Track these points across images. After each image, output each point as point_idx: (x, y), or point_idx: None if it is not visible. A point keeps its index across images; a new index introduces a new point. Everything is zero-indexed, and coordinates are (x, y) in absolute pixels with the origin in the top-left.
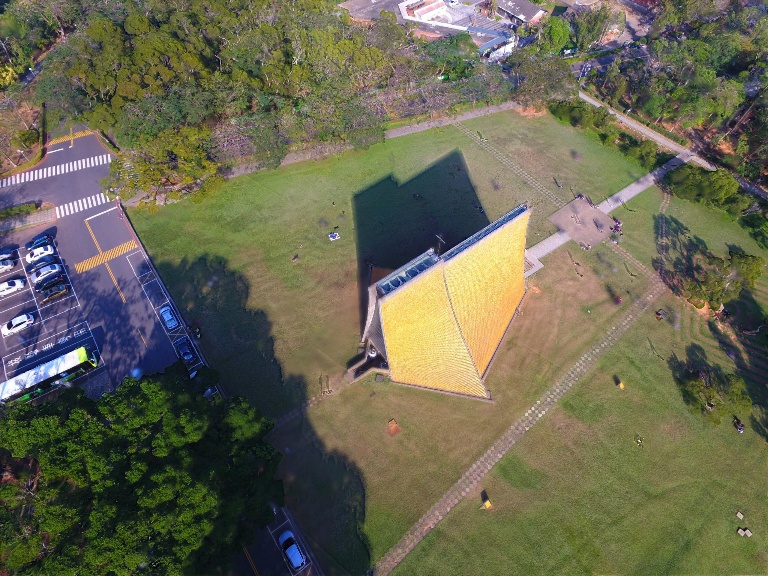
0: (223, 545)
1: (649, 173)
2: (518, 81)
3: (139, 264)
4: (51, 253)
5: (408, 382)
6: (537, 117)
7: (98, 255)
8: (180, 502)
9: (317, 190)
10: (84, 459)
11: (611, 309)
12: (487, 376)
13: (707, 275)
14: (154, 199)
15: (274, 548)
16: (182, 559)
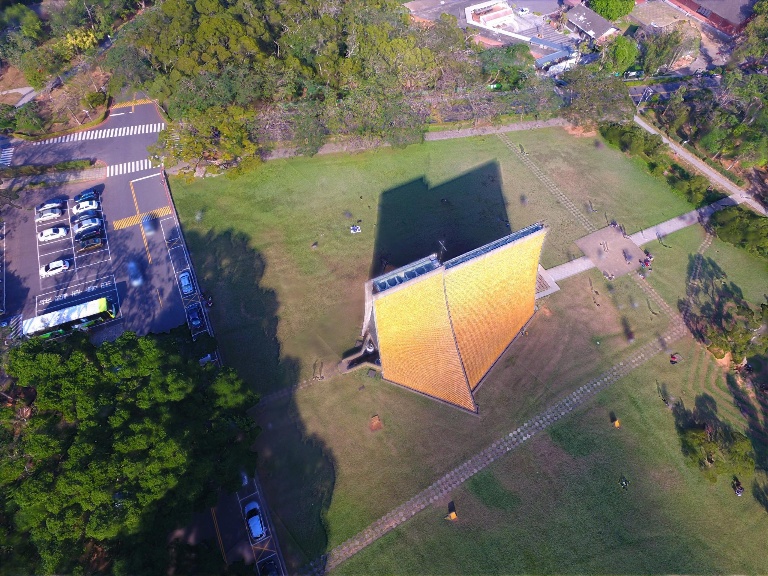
0: (186, 501)
1: (695, 210)
2: (571, 98)
3: (170, 229)
4: (95, 208)
5: (398, 382)
6: (585, 137)
7: (135, 216)
8: (151, 453)
9: (348, 182)
10: (75, 398)
11: (623, 344)
12: (478, 390)
13: (736, 325)
14: (193, 170)
15: (239, 515)
16: (143, 505)
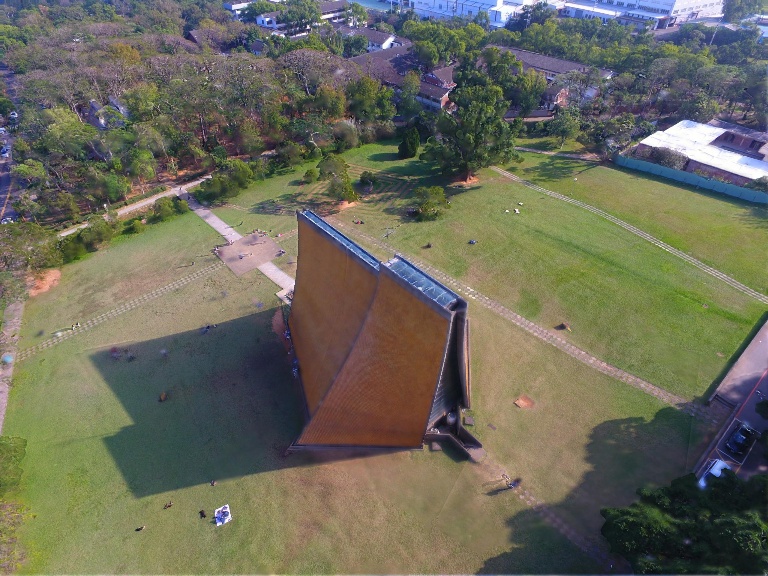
0: None
1: (193, 211)
2: None
3: None
4: None
5: None
6: (60, 277)
7: None
8: None
9: (88, 572)
10: None
11: None
12: None
13: (318, 198)
14: None
15: None
16: None
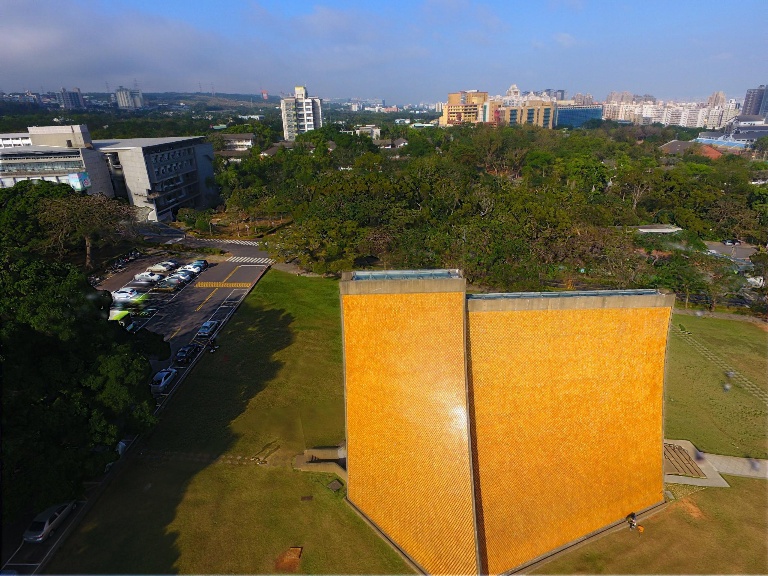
0: None
1: None
2: None
3: (236, 295)
4: (195, 272)
5: (366, 511)
6: None
7: (219, 282)
8: None
9: None
10: None
11: None
12: None
13: None
14: None
15: None
16: None
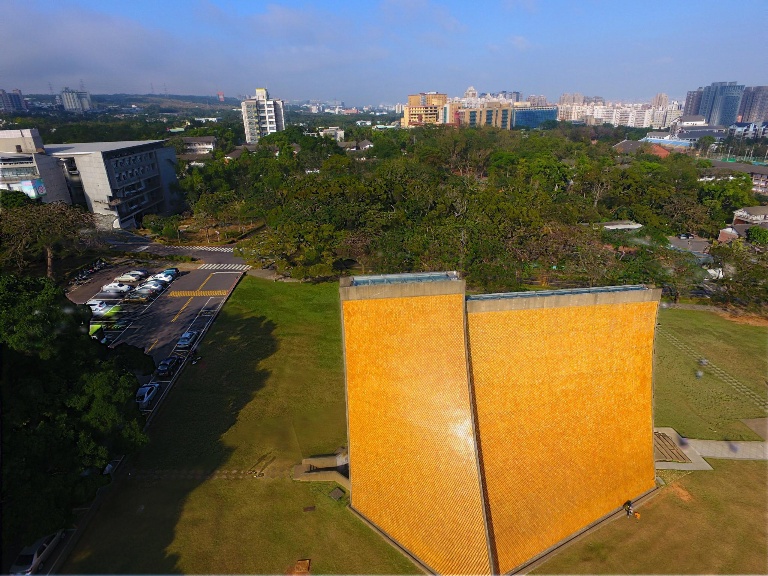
0: None
1: None
2: None
3: (213, 304)
4: (167, 281)
5: (372, 518)
6: (752, 325)
7: (194, 291)
8: None
9: None
10: None
11: None
12: None
13: None
14: None
15: None
16: None
